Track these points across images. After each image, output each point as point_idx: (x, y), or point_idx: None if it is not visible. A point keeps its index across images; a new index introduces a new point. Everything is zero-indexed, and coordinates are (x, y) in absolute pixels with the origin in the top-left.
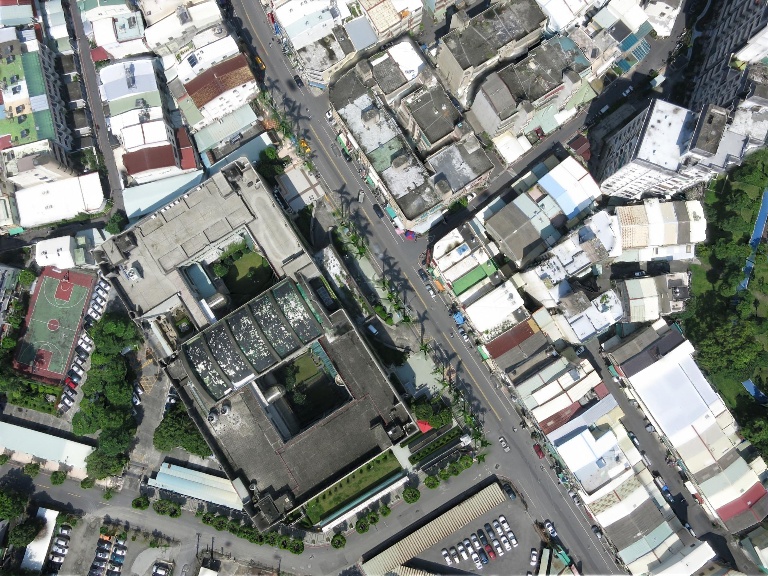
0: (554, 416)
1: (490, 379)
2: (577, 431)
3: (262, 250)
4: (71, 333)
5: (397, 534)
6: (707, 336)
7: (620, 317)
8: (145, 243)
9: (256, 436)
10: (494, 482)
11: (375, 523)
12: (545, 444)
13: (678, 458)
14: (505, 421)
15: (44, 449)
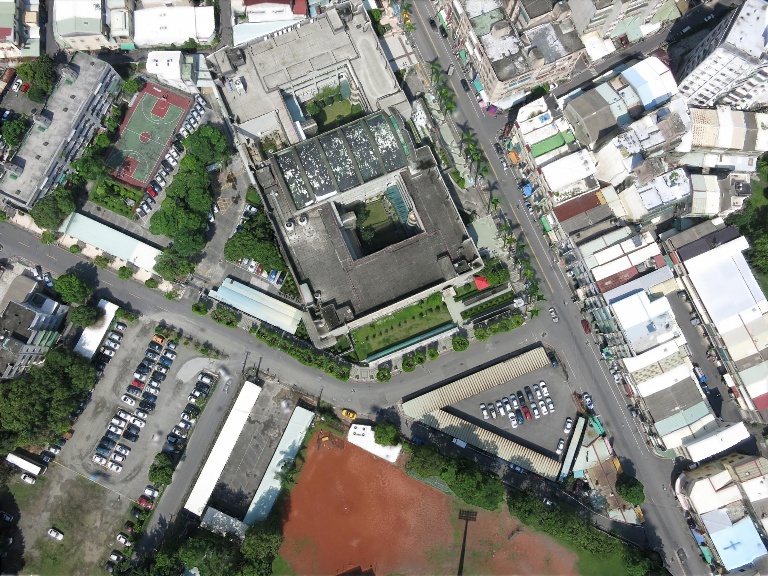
0: (612, 276)
1: (548, 253)
2: (633, 291)
3: (361, 85)
4: (160, 147)
5: (439, 383)
6: (762, 236)
7: (687, 194)
8: (254, 61)
9: (327, 251)
10: (540, 346)
11: (422, 363)
12: (594, 319)
13: (721, 347)
14: (557, 293)
15: (116, 246)
